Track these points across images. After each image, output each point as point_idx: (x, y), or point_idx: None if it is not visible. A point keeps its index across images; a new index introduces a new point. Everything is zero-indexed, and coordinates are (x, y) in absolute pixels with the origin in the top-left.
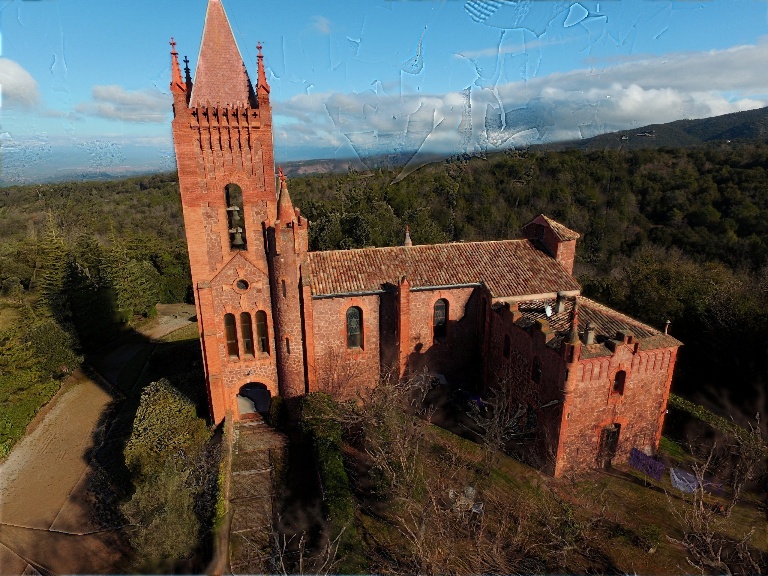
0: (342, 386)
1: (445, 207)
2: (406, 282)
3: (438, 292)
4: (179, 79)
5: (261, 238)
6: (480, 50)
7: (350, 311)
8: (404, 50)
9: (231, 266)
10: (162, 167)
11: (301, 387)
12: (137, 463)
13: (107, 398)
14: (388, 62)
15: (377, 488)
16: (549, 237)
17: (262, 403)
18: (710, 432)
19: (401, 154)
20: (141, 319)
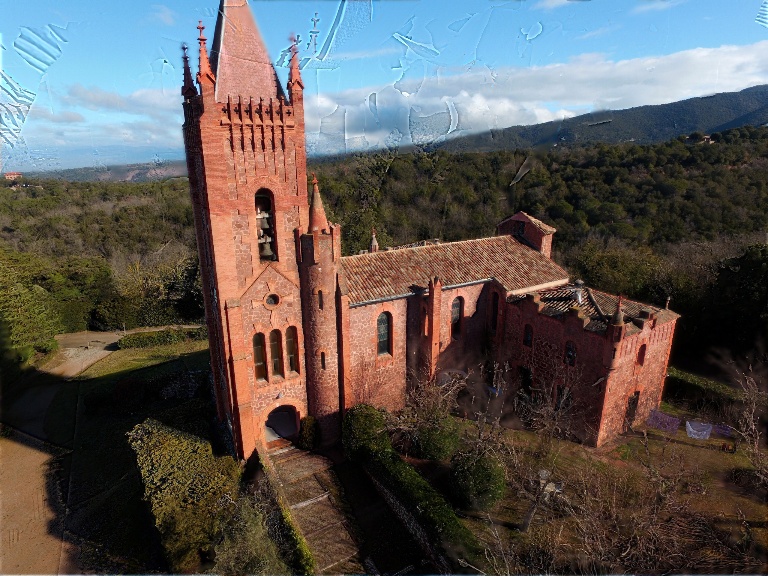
0: (372, 396)
1: (358, 208)
2: (439, 283)
3: (456, 290)
4: (208, 69)
5: (293, 247)
6: (498, 57)
7: (379, 317)
8: (468, 53)
9: (261, 280)
10: (36, 171)
11: (335, 403)
12: (172, 521)
13: (42, 456)
14: (450, 64)
15: (471, 489)
16: (531, 232)
17: (282, 427)
18: (689, 388)
19: (315, 156)
20: (38, 355)
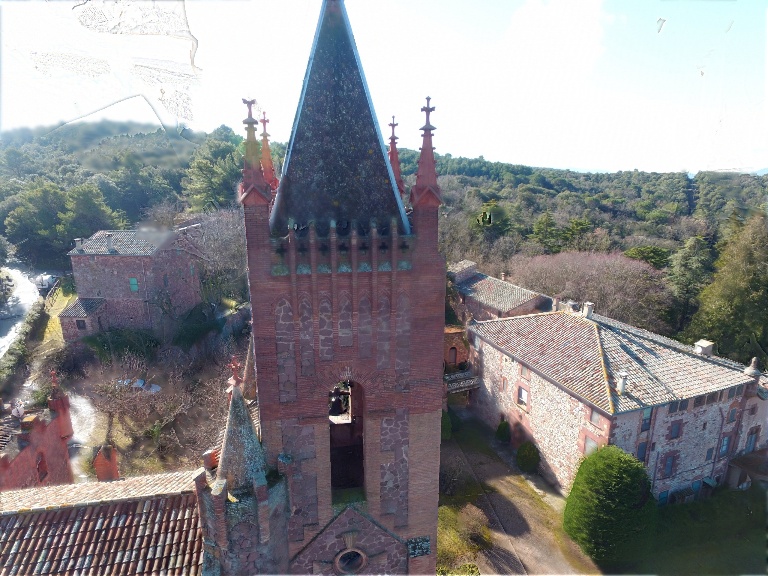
0: None
1: None
2: None
3: None
4: None
5: None
6: None
7: None
8: None
9: None
10: None
11: None
12: None
13: None
14: None
15: None
16: None
17: None
18: None
19: None
20: None
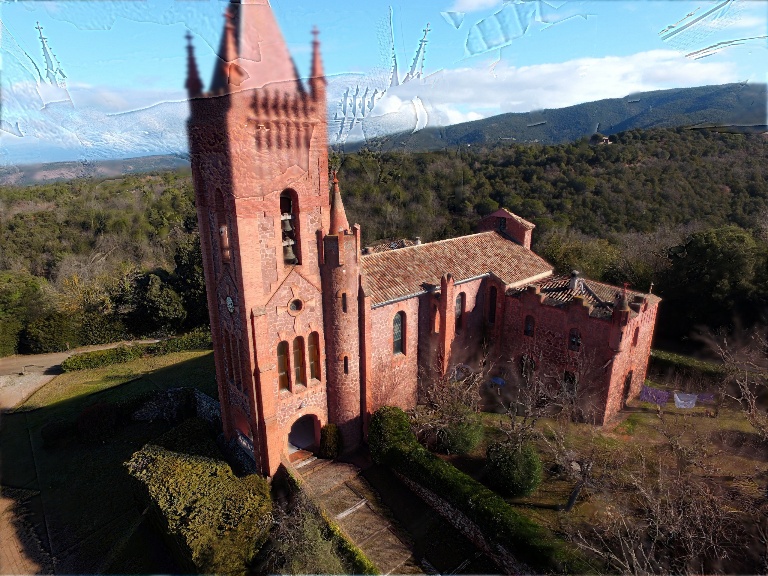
0: (388, 397)
1: None
2: (451, 279)
3: (459, 286)
4: None
5: (315, 249)
6: None
7: (394, 317)
8: (495, 54)
9: (286, 285)
10: None
11: (357, 407)
12: (210, 551)
13: (1, 502)
14: (478, 64)
15: (515, 477)
16: (513, 227)
17: (297, 439)
18: (663, 363)
19: None
20: None
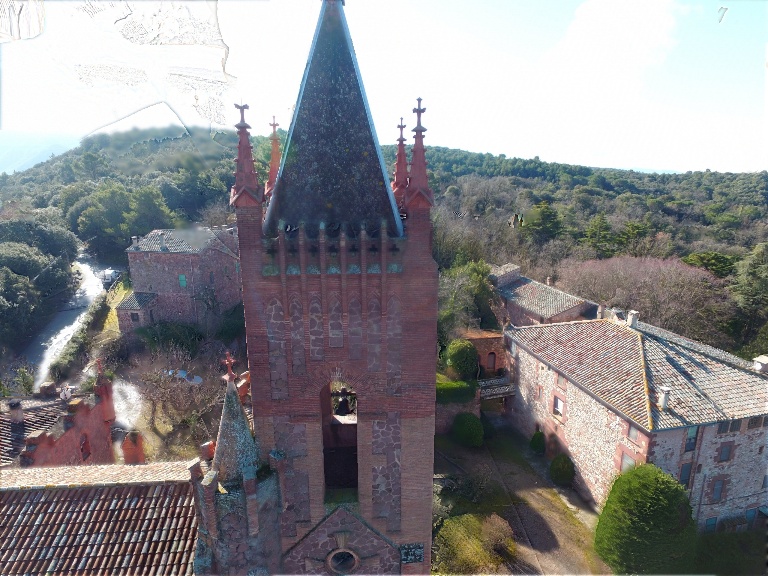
0: None
1: None
2: None
3: None
4: None
5: None
6: None
7: None
8: None
9: None
10: None
11: None
12: None
13: None
14: None
15: None
16: None
17: None
18: None
19: None
20: None
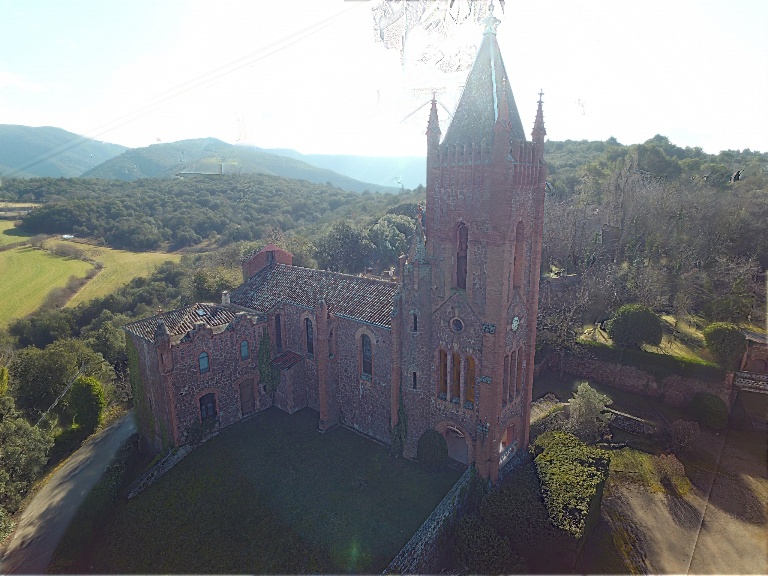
0: None
1: None
2: None
3: None
4: None
5: None
6: (359, 124)
7: None
8: None
9: None
10: None
11: None
12: None
13: None
14: None
15: None
16: (283, 257)
17: None
18: None
19: None
20: None
